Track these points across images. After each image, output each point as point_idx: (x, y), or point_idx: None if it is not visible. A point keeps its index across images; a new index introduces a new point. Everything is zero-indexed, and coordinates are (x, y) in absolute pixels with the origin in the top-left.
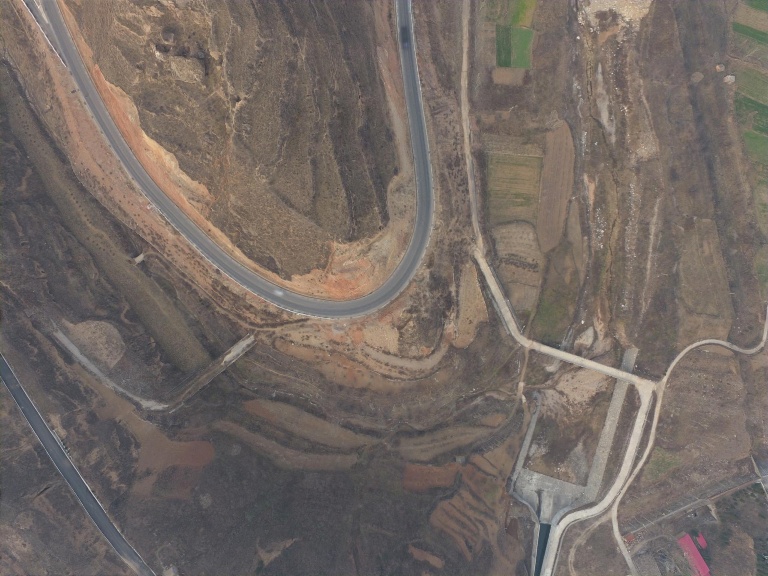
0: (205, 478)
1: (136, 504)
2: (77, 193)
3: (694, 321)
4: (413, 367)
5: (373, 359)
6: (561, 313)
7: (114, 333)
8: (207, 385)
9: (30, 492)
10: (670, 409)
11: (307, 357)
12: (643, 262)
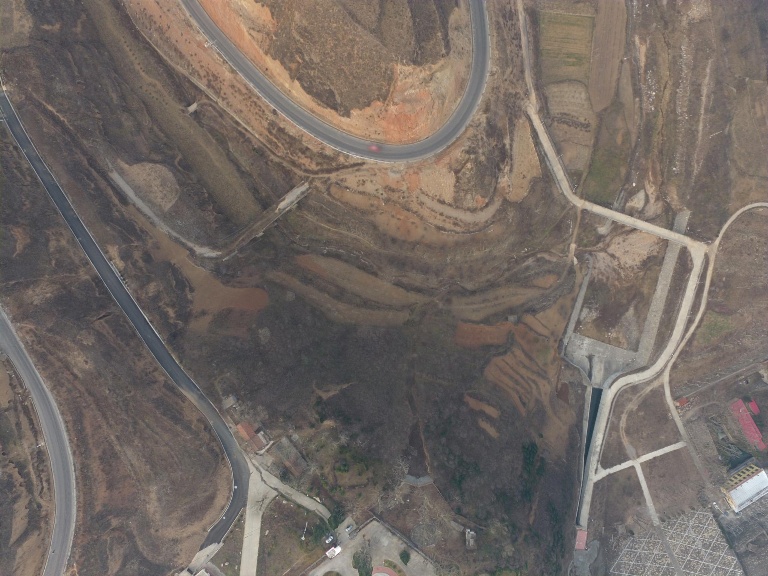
0: (261, 319)
1: (193, 338)
2: (131, 41)
3: (746, 183)
4: (467, 219)
5: (428, 208)
6: (613, 172)
7: (169, 176)
8: (259, 238)
9: (90, 315)
10: (722, 272)
11: (362, 205)
12: (695, 124)
